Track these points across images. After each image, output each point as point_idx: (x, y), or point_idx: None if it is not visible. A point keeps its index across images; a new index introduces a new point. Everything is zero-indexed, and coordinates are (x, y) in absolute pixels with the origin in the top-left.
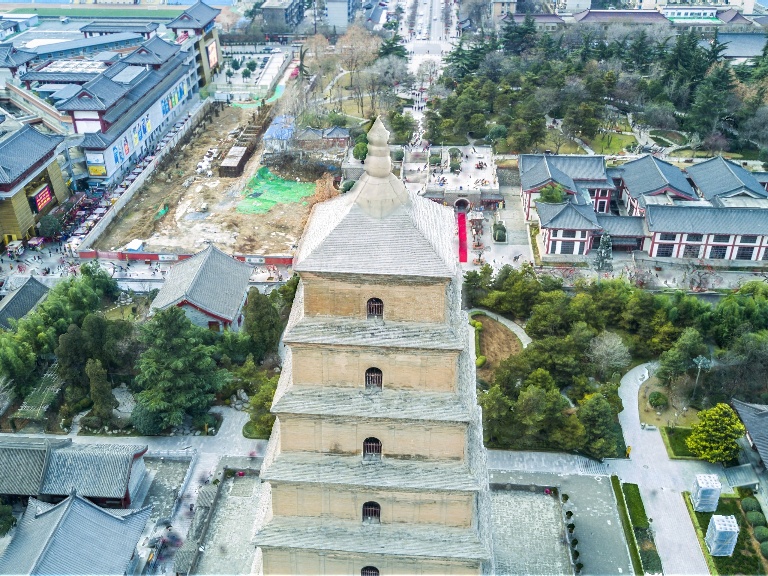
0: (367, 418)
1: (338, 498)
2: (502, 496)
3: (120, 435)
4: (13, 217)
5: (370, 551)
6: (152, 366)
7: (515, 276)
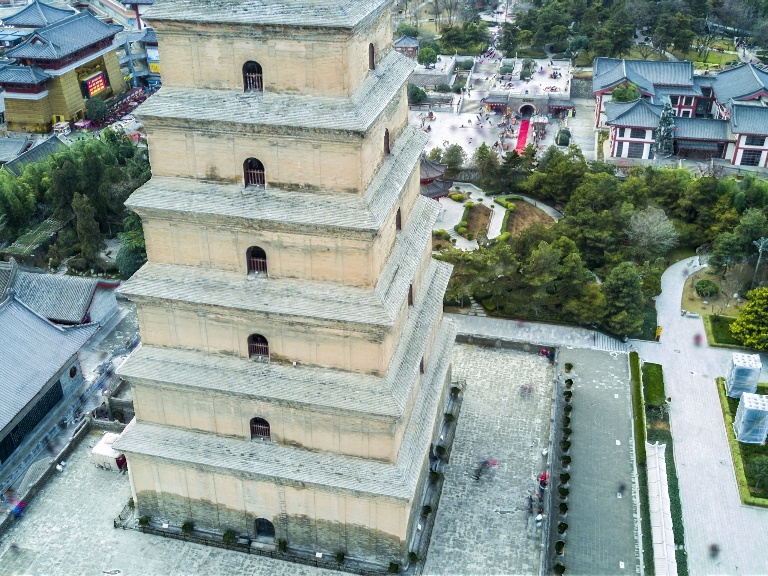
0: (242, 126)
1: (217, 240)
2: (489, 353)
3: None
4: (61, 97)
5: (251, 307)
6: None
7: (559, 157)
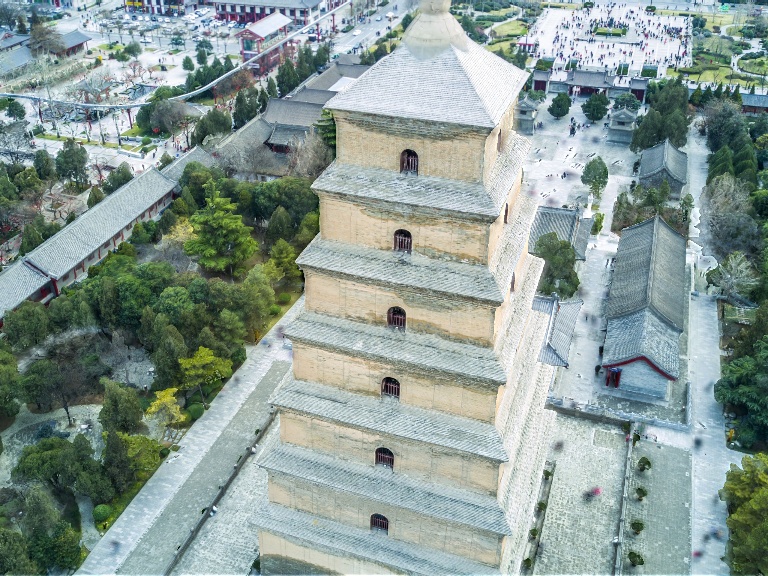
0: None
1: None
2: None
3: None
4: None
5: None
6: None
7: None
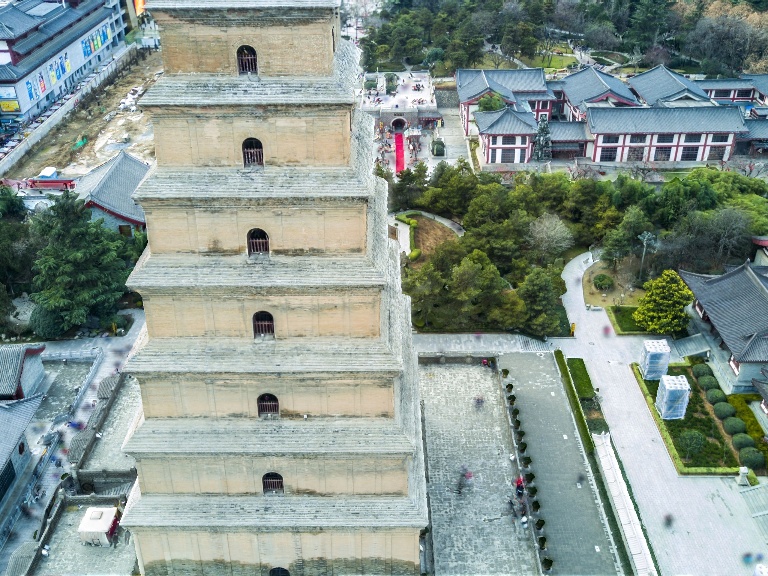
0: (247, 201)
1: (222, 309)
2: (436, 370)
3: (19, 342)
4: None
5: (263, 370)
6: (49, 261)
7: (451, 171)
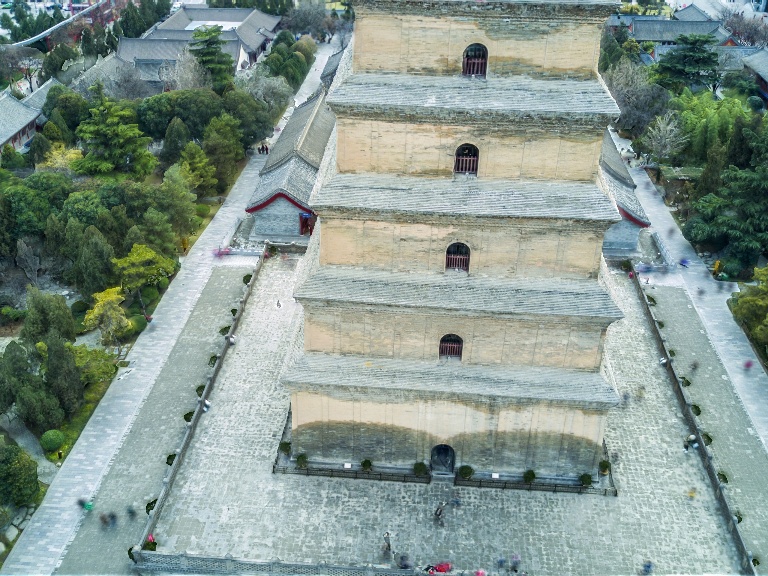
0: None
1: None
2: (710, 520)
3: None
4: None
5: None
6: (738, 171)
7: None
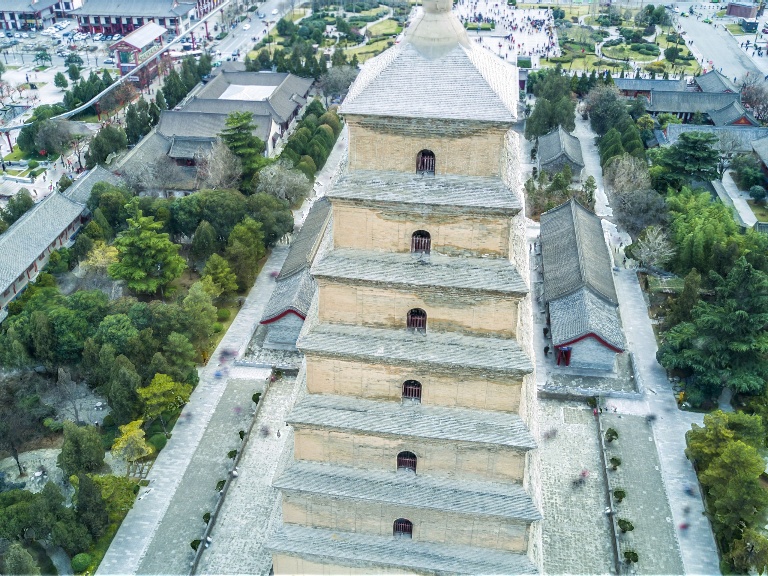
0: None
1: None
2: None
3: None
4: None
5: None
6: (706, 308)
7: None
